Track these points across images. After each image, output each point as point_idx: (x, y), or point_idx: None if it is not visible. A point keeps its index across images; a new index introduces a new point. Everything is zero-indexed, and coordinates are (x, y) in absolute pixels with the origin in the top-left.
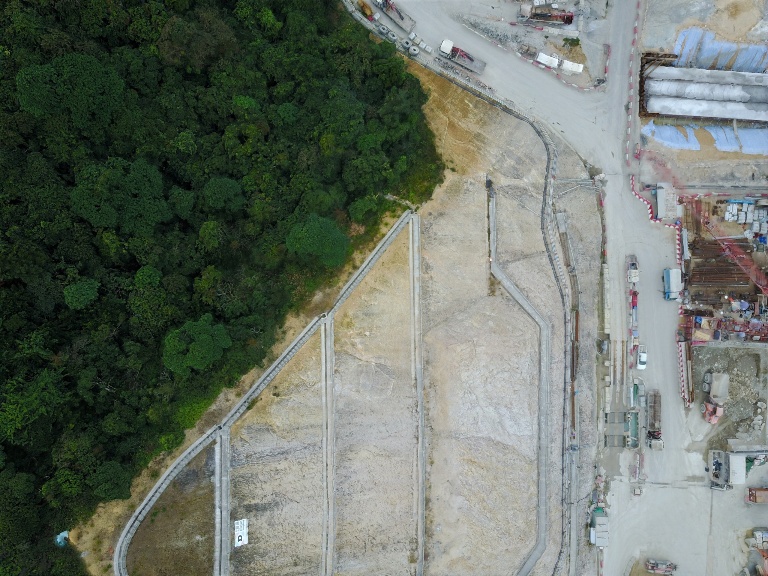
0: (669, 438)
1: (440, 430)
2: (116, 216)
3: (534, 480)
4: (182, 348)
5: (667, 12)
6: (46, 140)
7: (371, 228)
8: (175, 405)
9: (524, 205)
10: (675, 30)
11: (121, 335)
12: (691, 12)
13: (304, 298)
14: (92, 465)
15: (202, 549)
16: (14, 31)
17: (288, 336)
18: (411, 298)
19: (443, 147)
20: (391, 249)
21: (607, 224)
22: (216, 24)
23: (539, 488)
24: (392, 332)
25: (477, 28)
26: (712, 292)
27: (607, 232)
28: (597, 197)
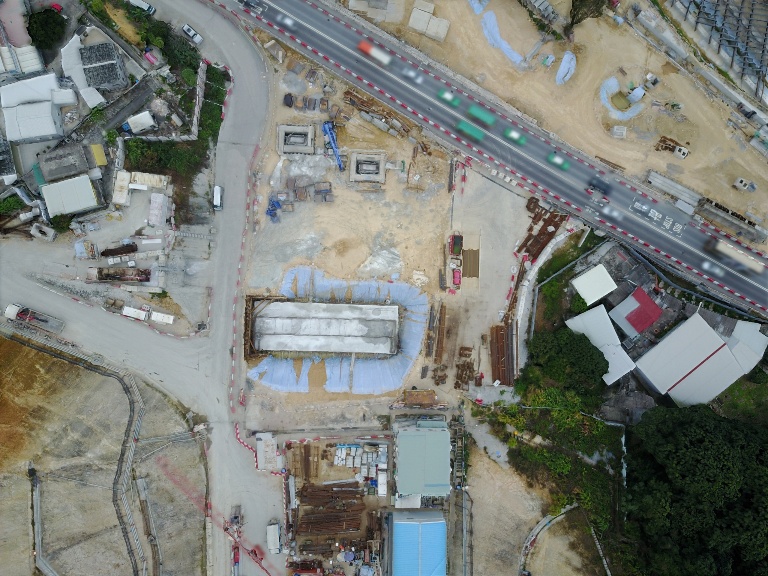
0: None
1: None
2: None
3: None
4: None
5: (273, 251)
6: None
7: None
8: None
9: (86, 483)
10: (282, 269)
11: None
12: (297, 251)
13: None
14: None
15: None
16: None
17: None
18: None
19: None
20: None
21: (213, 474)
22: None
23: None
24: None
25: (54, 285)
26: (322, 540)
27: (212, 482)
28: (202, 446)
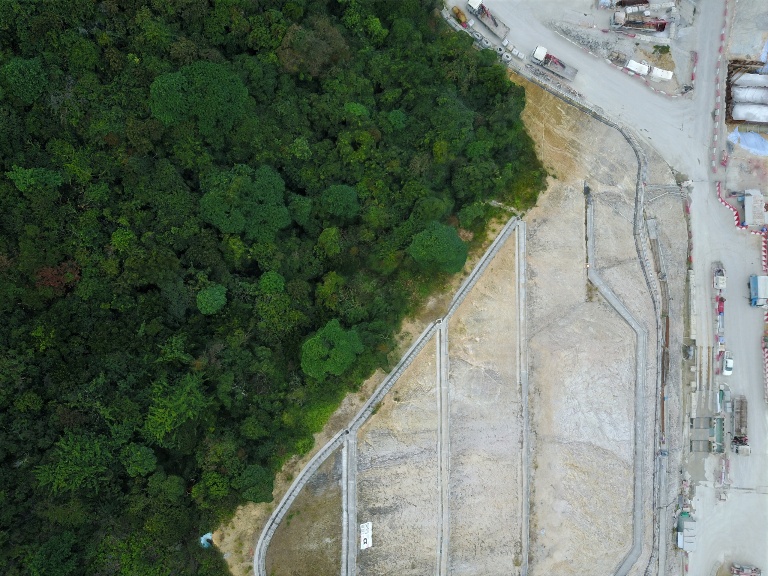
0: (754, 444)
1: (544, 435)
2: (244, 222)
3: (631, 485)
4: (325, 354)
5: (754, 19)
6: (173, 147)
7: (479, 235)
8: (303, 409)
9: (618, 212)
10: (762, 37)
11: (250, 340)
12: None
13: (420, 304)
14: (237, 469)
15: (331, 551)
16: (145, 39)
17: (406, 341)
18: (516, 304)
19: (542, 154)
20: (499, 255)
21: (693, 230)
22: (331, 32)
23: (635, 493)
24: (499, 338)
25: (568, 35)
26: None
27: (693, 238)
28: (683, 203)
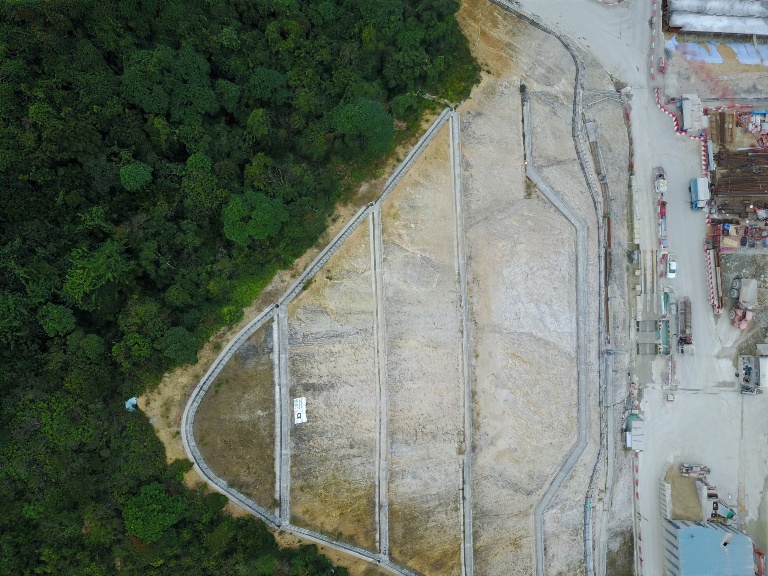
0: (699, 345)
1: (484, 324)
2: (168, 100)
3: (574, 377)
4: (245, 213)
5: None
6: (95, 28)
7: (413, 124)
8: (232, 284)
9: (556, 112)
10: None
11: (177, 216)
12: None
13: (352, 187)
14: (159, 330)
15: (263, 424)
16: None
17: (338, 223)
18: (453, 194)
19: (477, 52)
20: (433, 145)
21: (634, 137)
22: None
23: (579, 386)
24: (436, 226)
25: None
26: (737, 202)
27: (634, 145)
28: (623, 111)
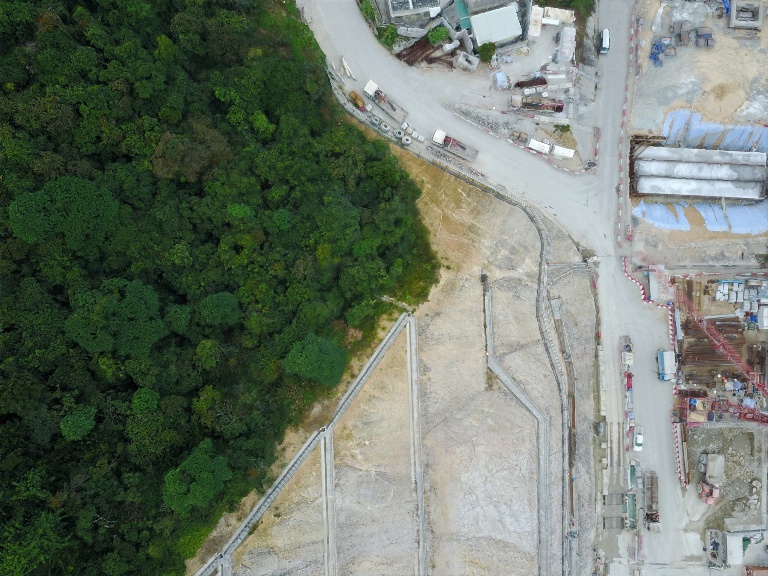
0: (667, 518)
1: (441, 533)
2: (112, 342)
3: (535, 575)
4: (183, 490)
5: (655, 94)
6: (40, 264)
7: (368, 334)
8: (175, 535)
9: (519, 295)
10: (663, 112)
11: (119, 464)
12: (678, 94)
13: (303, 412)
14: None
15: None
16: (6, 157)
17: (288, 453)
18: (410, 401)
19: (438, 243)
20: (389, 354)
21: (601, 305)
22: (210, 135)
23: None
24: (391, 438)
25: (469, 116)
26: (705, 371)
27: (601, 313)
28: (590, 279)
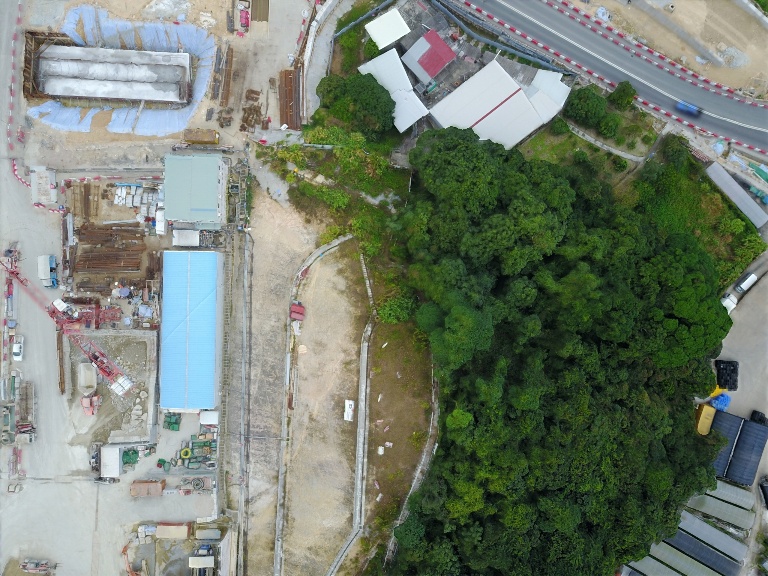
0: (51, 431)
1: None
2: None
3: None
4: None
5: None
6: None
7: None
8: None
9: None
10: (64, 8)
11: None
12: None
13: None
14: None
15: None
16: None
17: None
18: None
19: None
20: None
21: None
22: None
23: None
24: None
25: None
26: (101, 279)
27: None
28: None
